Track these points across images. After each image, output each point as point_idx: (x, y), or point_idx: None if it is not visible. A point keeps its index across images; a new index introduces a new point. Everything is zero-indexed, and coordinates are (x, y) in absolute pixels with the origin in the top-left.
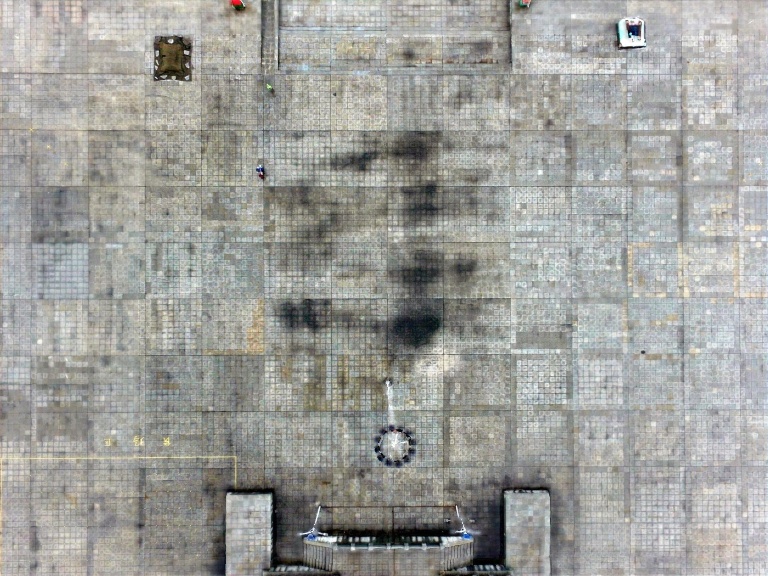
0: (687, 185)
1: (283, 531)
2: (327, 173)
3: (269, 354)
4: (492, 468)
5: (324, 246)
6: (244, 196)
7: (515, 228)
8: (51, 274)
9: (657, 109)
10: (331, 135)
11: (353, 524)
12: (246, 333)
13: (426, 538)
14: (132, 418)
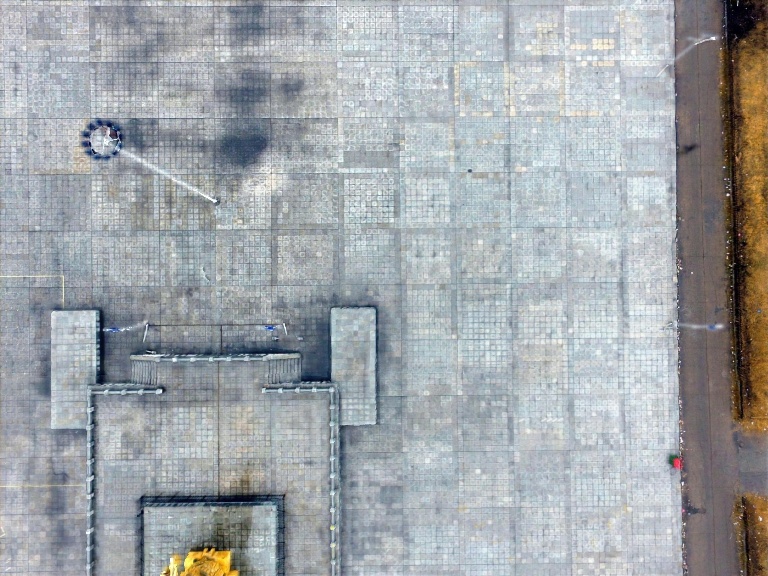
0: (513, 5)
1: (111, 349)
2: None
3: (96, 174)
4: (320, 286)
5: (151, 66)
6: (69, 15)
7: (342, 47)
8: None
9: None
10: None
11: (181, 342)
12: (73, 153)
13: (253, 354)
14: None
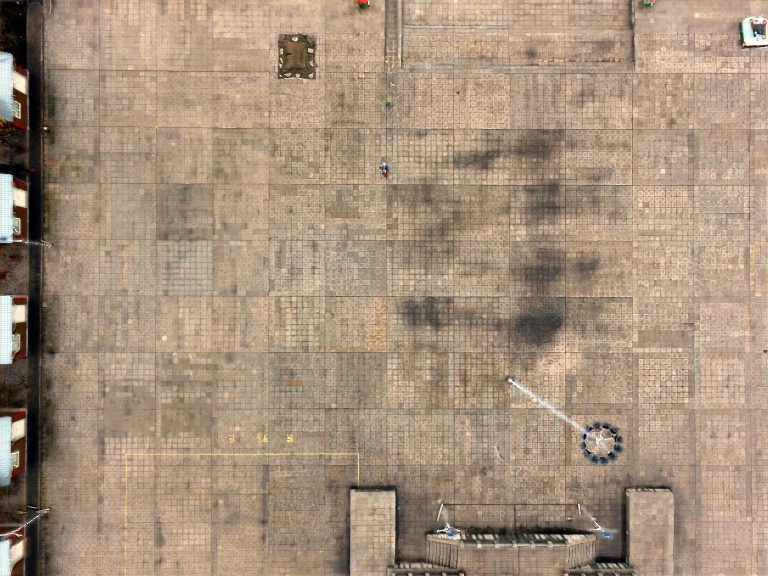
0: None
1: (405, 528)
2: (450, 171)
3: (392, 352)
4: (614, 466)
5: (447, 244)
6: (367, 194)
7: (637, 227)
8: (175, 271)
9: None
10: (454, 133)
11: (475, 521)
12: (369, 330)
13: (549, 536)
14: (256, 415)
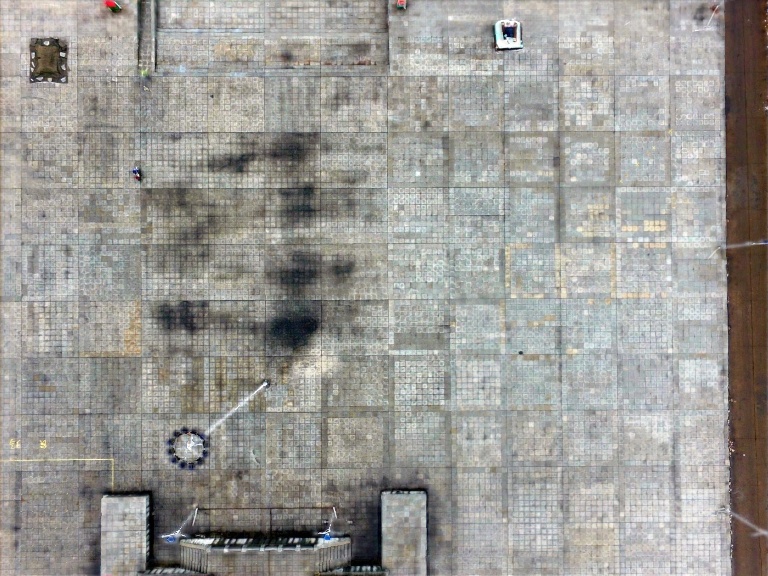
0: (564, 186)
1: (160, 533)
2: (204, 175)
3: (146, 356)
4: (370, 469)
5: (202, 248)
6: (121, 198)
7: (393, 229)
8: None
9: (534, 110)
10: (208, 137)
11: (231, 526)
12: (123, 335)
13: (303, 539)
14: (8, 421)
